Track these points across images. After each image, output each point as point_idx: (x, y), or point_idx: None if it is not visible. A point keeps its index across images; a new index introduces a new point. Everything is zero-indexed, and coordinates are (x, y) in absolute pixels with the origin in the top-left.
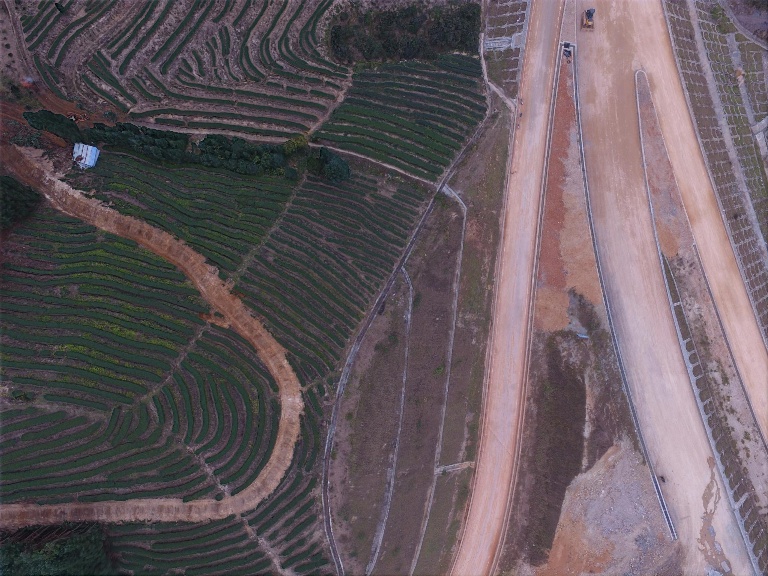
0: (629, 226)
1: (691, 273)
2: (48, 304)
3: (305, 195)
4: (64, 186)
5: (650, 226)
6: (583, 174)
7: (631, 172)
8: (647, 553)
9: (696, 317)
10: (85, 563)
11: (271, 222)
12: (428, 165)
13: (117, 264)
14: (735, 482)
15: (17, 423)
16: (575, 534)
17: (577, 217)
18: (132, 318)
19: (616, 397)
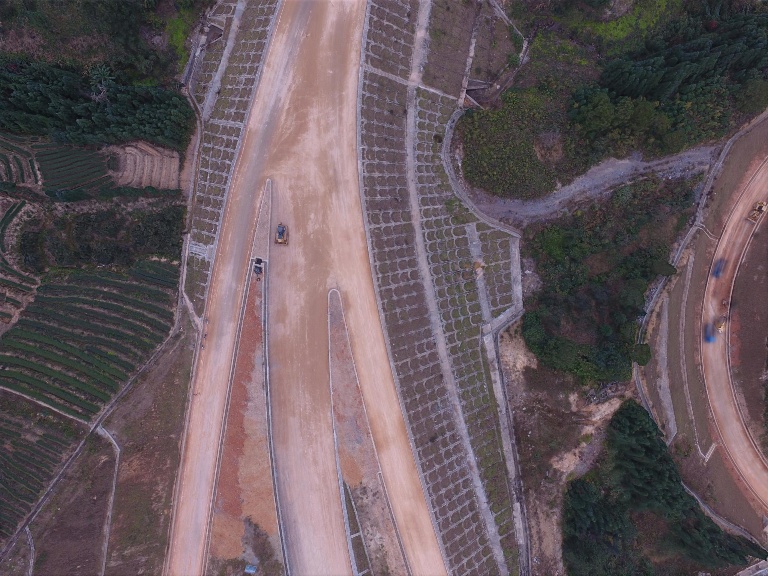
0: (311, 453)
1: (374, 503)
2: None
3: None
4: None
5: (333, 454)
6: (267, 398)
7: (317, 397)
8: None
9: (377, 547)
10: None
11: None
12: (83, 403)
13: None
14: None
15: None
16: None
17: (257, 444)
18: None
19: None
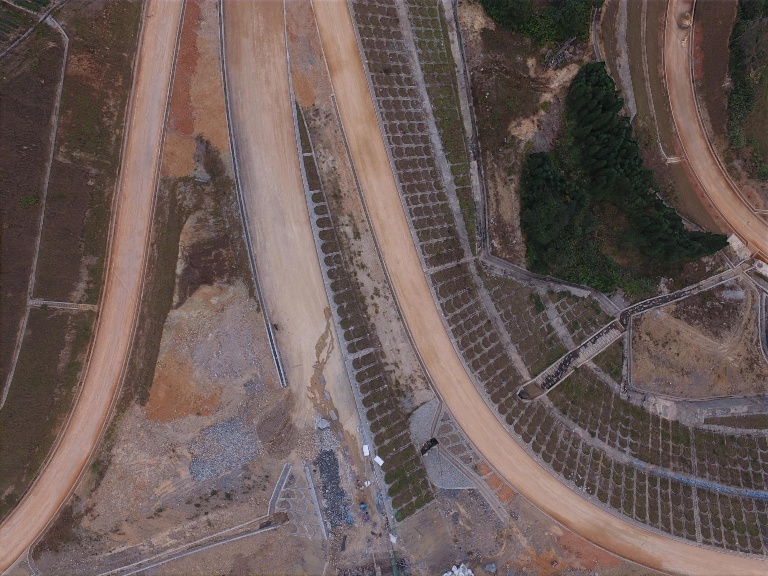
0: (264, 74)
1: (327, 124)
2: None
3: None
4: None
5: (286, 74)
6: (220, 19)
7: (271, 18)
8: (254, 398)
9: (330, 169)
10: None
11: None
12: None
13: None
14: (355, 335)
15: None
16: (182, 376)
17: (209, 62)
18: None
19: (235, 244)
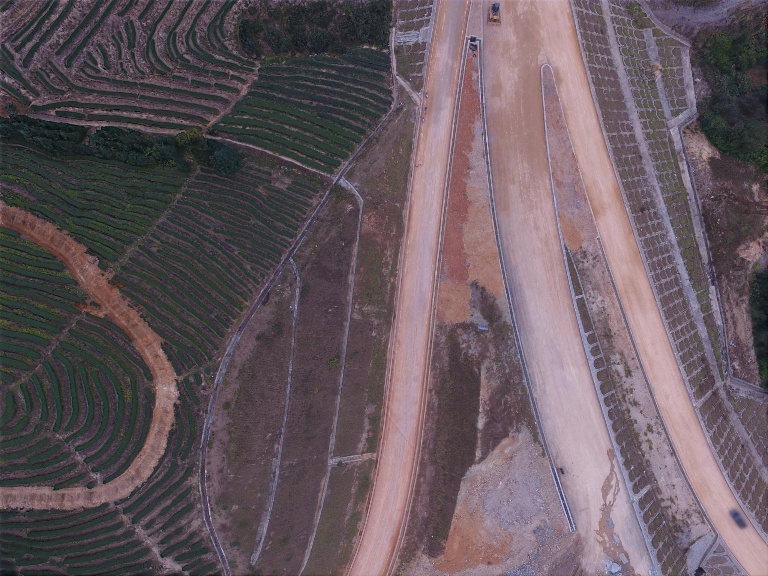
0: (533, 219)
1: (594, 266)
2: None
3: (196, 187)
4: None
5: (554, 219)
6: (487, 167)
7: (535, 165)
8: (545, 545)
9: (599, 310)
10: None
11: (159, 213)
12: (325, 157)
13: None
14: (636, 474)
15: None
16: (473, 525)
17: (480, 210)
18: (6, 307)
19: (516, 389)
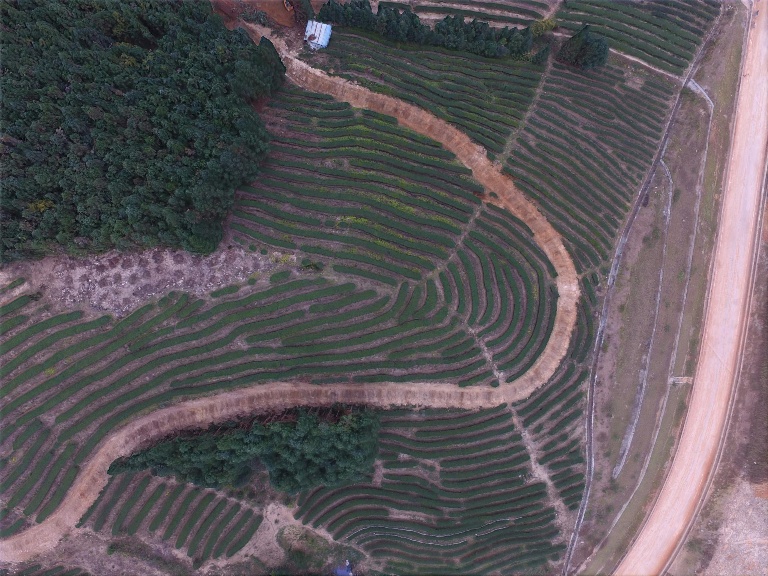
0: None
1: None
2: (322, 176)
3: (555, 81)
4: (303, 64)
5: None
6: None
7: None
8: None
9: None
10: (370, 441)
11: None
12: (673, 58)
13: (384, 139)
14: None
15: (307, 293)
16: None
17: None
18: (408, 194)
19: None
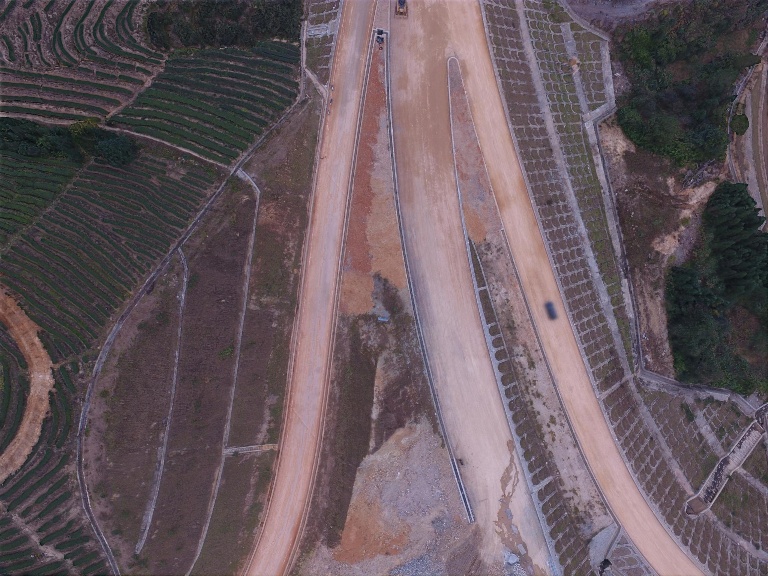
0: (437, 211)
1: (498, 258)
2: None
3: (87, 177)
4: None
5: (458, 211)
6: (392, 159)
7: (440, 158)
8: (443, 535)
9: (503, 302)
10: None
11: (47, 203)
12: (223, 149)
13: None
14: (537, 465)
15: None
16: (371, 516)
17: (384, 202)
18: None
19: (417, 380)
